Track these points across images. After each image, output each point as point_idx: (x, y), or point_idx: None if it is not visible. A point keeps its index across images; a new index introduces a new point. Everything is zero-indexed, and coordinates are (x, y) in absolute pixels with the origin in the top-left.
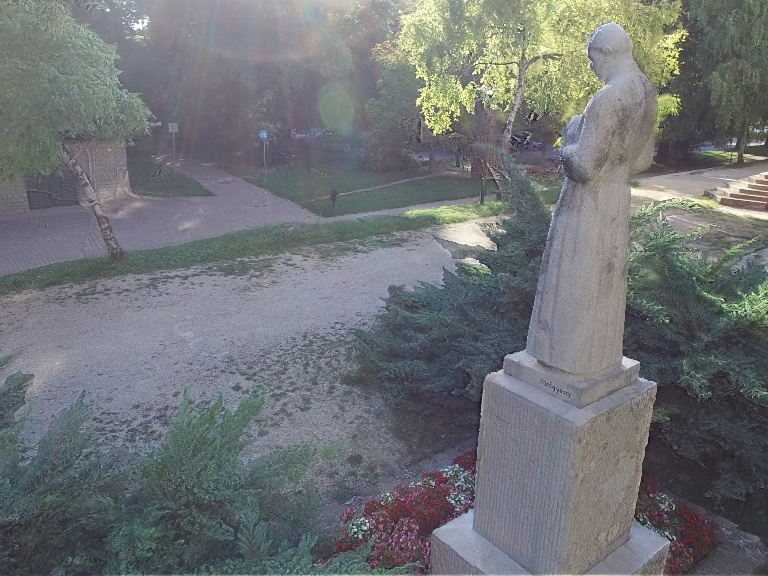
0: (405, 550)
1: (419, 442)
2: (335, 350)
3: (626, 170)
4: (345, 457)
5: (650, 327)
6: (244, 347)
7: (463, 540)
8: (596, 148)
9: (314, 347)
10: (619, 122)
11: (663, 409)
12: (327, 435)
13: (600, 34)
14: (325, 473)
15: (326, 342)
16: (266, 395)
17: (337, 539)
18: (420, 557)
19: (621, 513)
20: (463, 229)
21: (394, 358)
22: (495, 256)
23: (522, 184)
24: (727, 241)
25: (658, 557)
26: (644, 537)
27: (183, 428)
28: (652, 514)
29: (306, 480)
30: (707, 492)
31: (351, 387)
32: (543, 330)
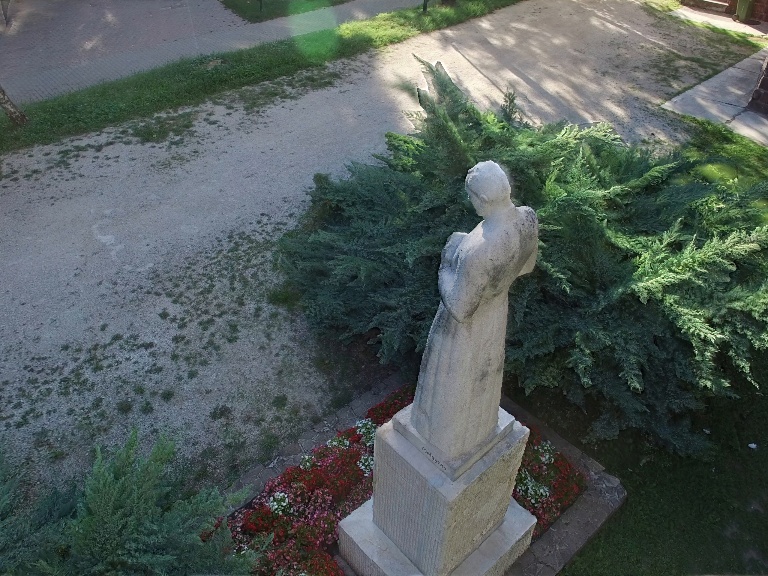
0: (318, 527)
1: (340, 376)
2: (261, 256)
3: (501, 296)
4: (271, 399)
5: (554, 285)
6: (168, 255)
7: (364, 533)
8: (466, 302)
9: (240, 252)
10: (490, 278)
11: (556, 367)
12: (254, 373)
13: (476, 179)
14: (252, 420)
15: (252, 244)
16: (194, 323)
17: (250, 571)
18: (332, 530)
19: (495, 514)
20: (401, 54)
21: (318, 277)
22: (414, 185)
23: (438, 127)
24: (676, 66)
25: (525, 534)
26: (516, 518)
27: (100, 489)
28: (533, 469)
29: (235, 429)
30: (585, 438)
31: (277, 307)
32: (423, 414)
